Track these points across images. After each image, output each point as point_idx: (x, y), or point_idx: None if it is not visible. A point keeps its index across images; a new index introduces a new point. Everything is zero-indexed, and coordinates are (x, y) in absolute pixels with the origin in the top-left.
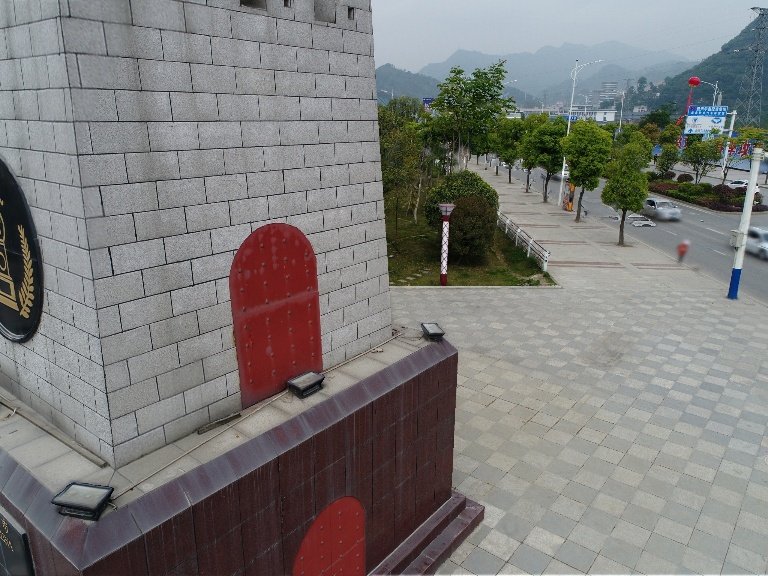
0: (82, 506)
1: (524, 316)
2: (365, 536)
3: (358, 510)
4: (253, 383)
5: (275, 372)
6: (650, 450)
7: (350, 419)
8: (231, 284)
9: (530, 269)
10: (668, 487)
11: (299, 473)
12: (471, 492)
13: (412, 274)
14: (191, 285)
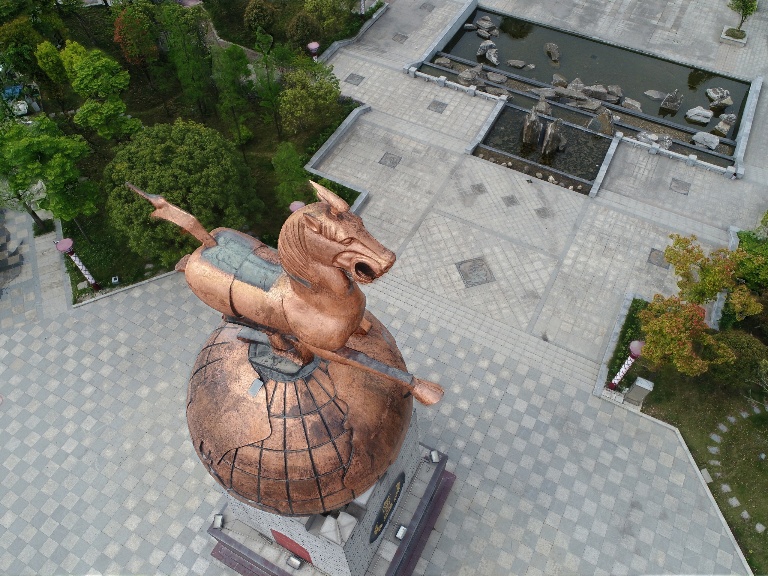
0: (213, 524)
1: None
2: None
3: None
4: None
5: None
6: None
7: None
8: None
9: None
10: None
11: None
12: None
13: None
14: None
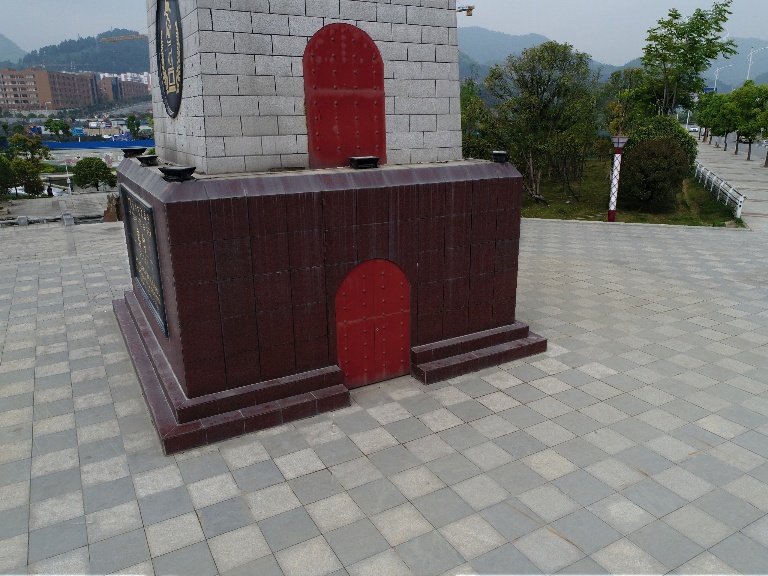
0: (173, 169)
1: (687, 246)
2: (410, 309)
3: (403, 281)
4: (320, 151)
5: (340, 149)
6: (766, 337)
7: (394, 191)
8: (304, 64)
9: (722, 218)
10: (767, 360)
11: (342, 216)
12: (545, 337)
13: (583, 215)
14: (271, 55)
